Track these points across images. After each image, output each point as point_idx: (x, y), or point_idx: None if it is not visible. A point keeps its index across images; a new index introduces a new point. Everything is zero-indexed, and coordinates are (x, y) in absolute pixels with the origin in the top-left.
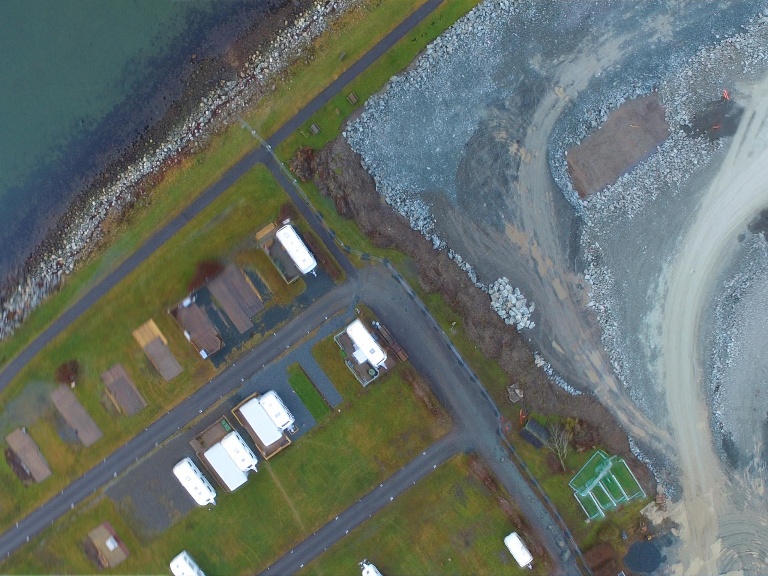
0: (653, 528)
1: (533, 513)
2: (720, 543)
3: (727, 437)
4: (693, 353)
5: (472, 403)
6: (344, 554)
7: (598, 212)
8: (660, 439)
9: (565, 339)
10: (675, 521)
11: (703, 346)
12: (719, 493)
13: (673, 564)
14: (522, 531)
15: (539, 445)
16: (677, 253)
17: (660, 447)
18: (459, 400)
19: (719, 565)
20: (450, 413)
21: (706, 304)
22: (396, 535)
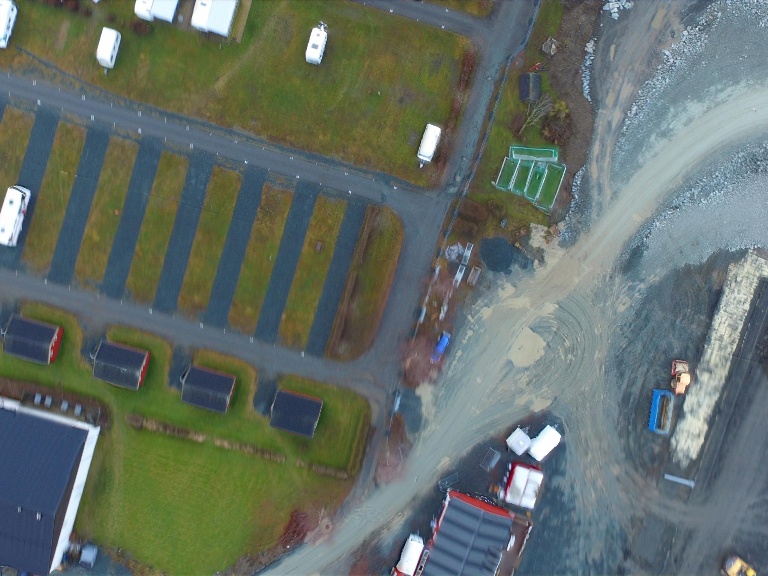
0: (526, 244)
1: (466, 136)
2: (555, 308)
3: (643, 247)
4: (690, 164)
5: (516, 18)
6: (318, 6)
7: (742, 3)
8: (601, 192)
9: (623, 53)
10: (545, 257)
11: (701, 168)
12: (594, 276)
13: (509, 282)
14: (446, 134)
15: (525, 95)
16: (760, 85)
17: (595, 197)
18: (510, 6)
19: (537, 321)
20: (495, 6)
21: (737, 141)
22: (365, 37)
